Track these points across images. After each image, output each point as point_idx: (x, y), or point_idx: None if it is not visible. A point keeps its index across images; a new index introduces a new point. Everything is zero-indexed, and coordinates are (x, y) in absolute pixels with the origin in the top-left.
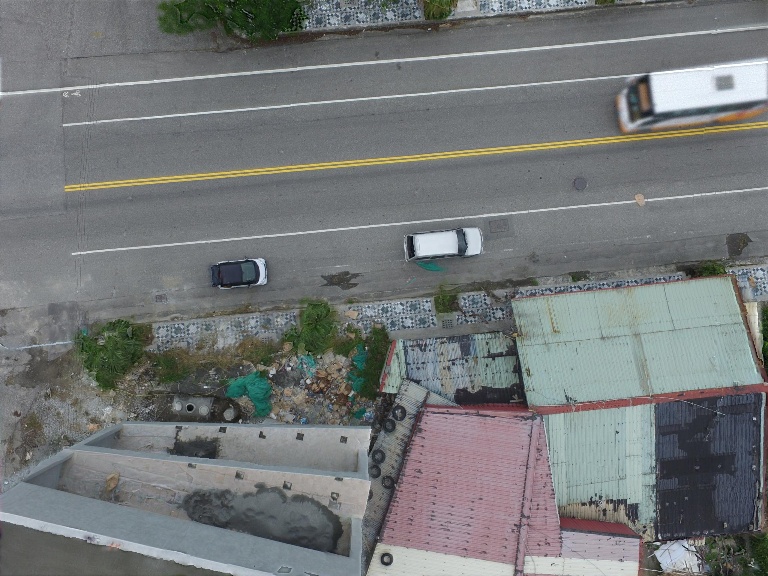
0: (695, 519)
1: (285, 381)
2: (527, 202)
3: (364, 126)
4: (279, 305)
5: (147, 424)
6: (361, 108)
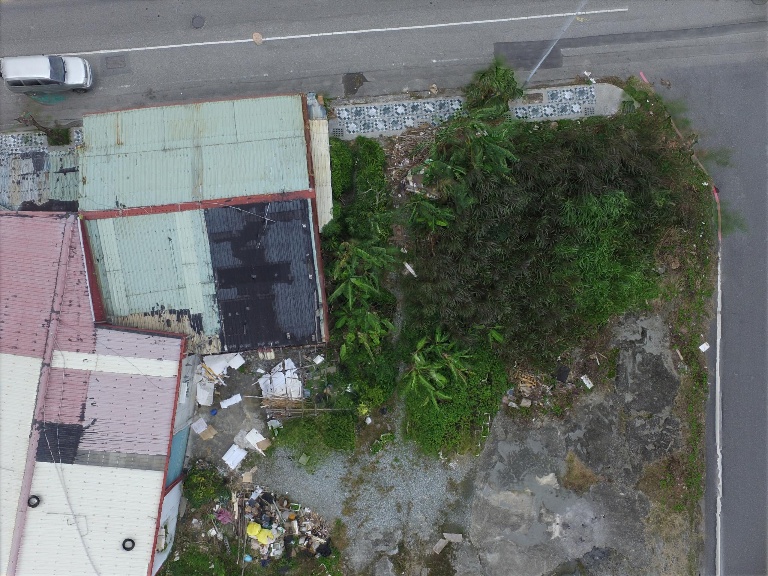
0: (259, 330)
1: None
2: (144, 39)
3: None
4: None
5: None
6: None
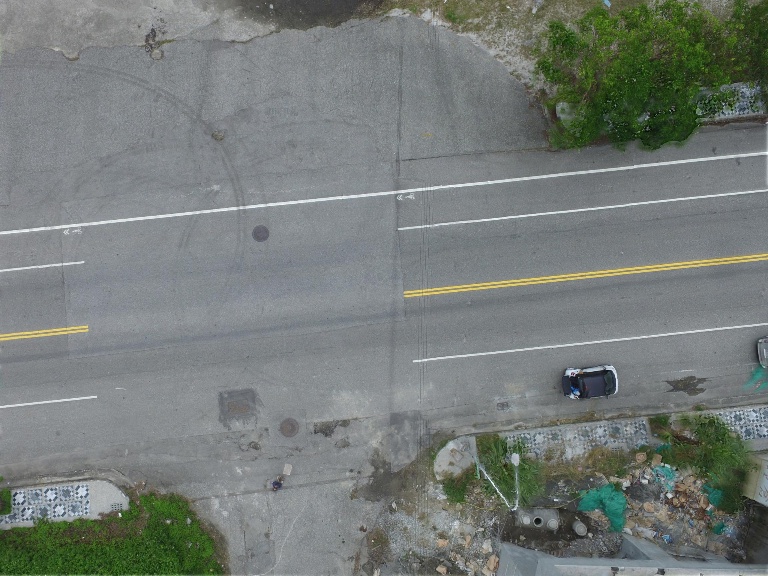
0: None
1: (644, 495)
2: None
3: (706, 225)
4: (625, 412)
5: (580, 565)
6: (702, 206)
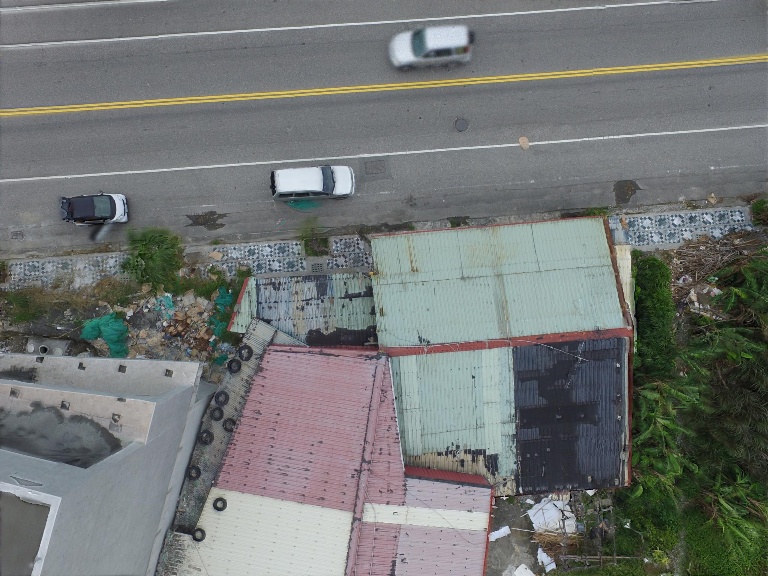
0: (558, 472)
1: (141, 323)
2: (405, 143)
3: (235, 60)
4: None
5: None
6: (233, 41)
